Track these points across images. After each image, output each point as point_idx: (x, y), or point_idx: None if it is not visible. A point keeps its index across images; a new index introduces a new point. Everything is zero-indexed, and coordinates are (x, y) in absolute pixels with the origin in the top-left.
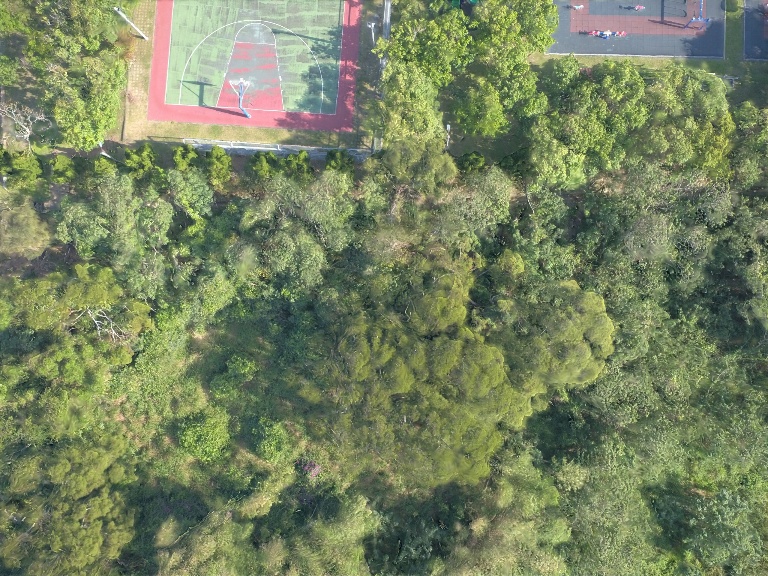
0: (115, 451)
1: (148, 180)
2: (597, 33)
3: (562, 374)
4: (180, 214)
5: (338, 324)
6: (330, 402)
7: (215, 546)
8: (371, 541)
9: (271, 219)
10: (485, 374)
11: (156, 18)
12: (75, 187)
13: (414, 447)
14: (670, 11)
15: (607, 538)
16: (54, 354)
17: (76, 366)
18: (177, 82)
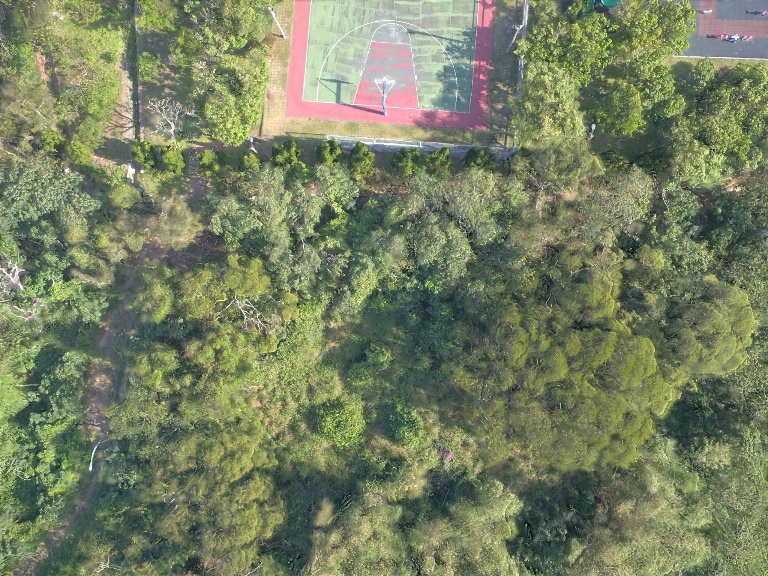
0: (257, 436)
1: (291, 175)
2: (725, 37)
3: (711, 364)
4: (324, 208)
5: (485, 315)
6: (462, 391)
7: (371, 527)
8: None
9: (417, 213)
10: (641, 364)
11: (294, 17)
12: (211, 181)
13: (570, 433)
14: None
15: (743, 522)
16: (213, 342)
17: (232, 353)
18: (315, 80)
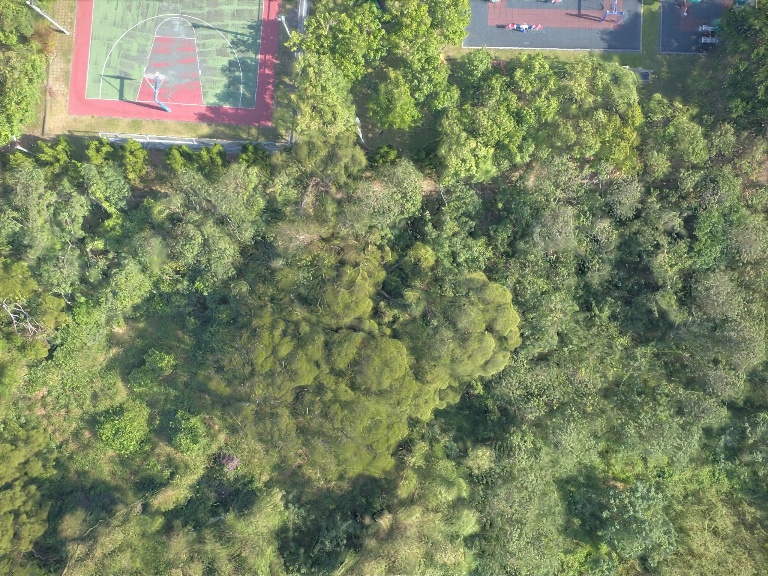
0: (33, 444)
1: (65, 174)
2: (514, 26)
3: (464, 366)
4: (96, 208)
5: (248, 317)
6: None
7: (122, 538)
8: (288, 534)
9: (184, 212)
10: (385, 366)
11: (77, 12)
12: None
13: (315, 439)
14: (587, 4)
15: (515, 530)
16: None
17: None
18: (97, 76)
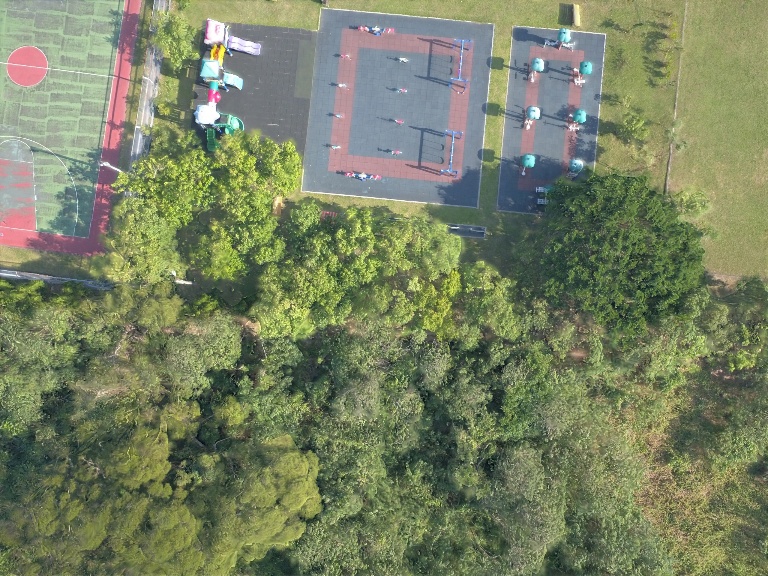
0: None
1: None
2: (352, 175)
3: (252, 540)
4: None
5: (51, 465)
6: None
7: None
8: None
9: None
10: (167, 540)
11: None
12: None
13: None
14: (428, 157)
15: None
16: None
17: None
18: None
